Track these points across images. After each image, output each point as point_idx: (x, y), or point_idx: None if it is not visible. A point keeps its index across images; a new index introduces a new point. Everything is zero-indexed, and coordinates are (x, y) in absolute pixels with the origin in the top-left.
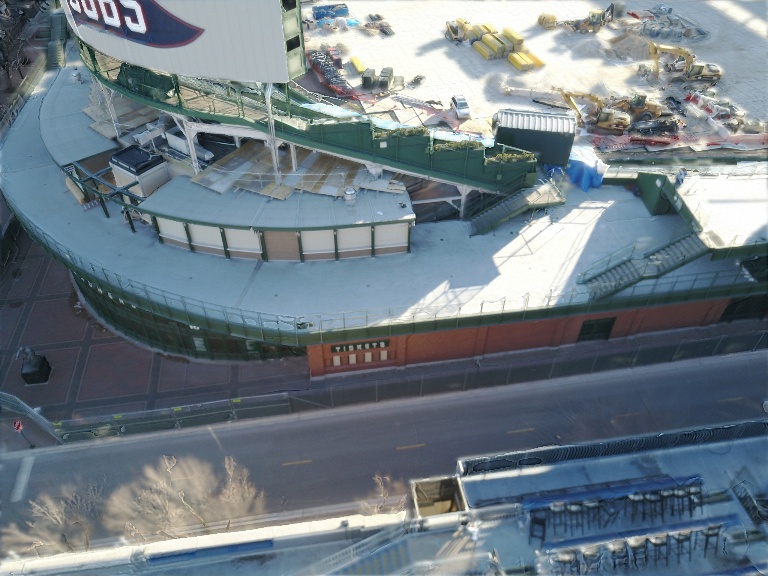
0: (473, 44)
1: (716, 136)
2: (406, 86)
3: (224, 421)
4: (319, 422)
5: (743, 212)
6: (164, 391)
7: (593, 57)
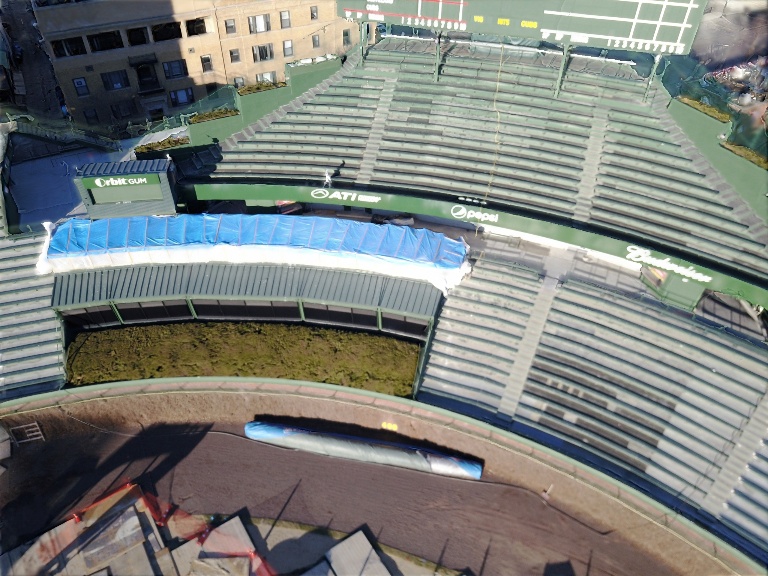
0: None
1: None
2: None
3: None
4: None
5: None
6: None
7: None
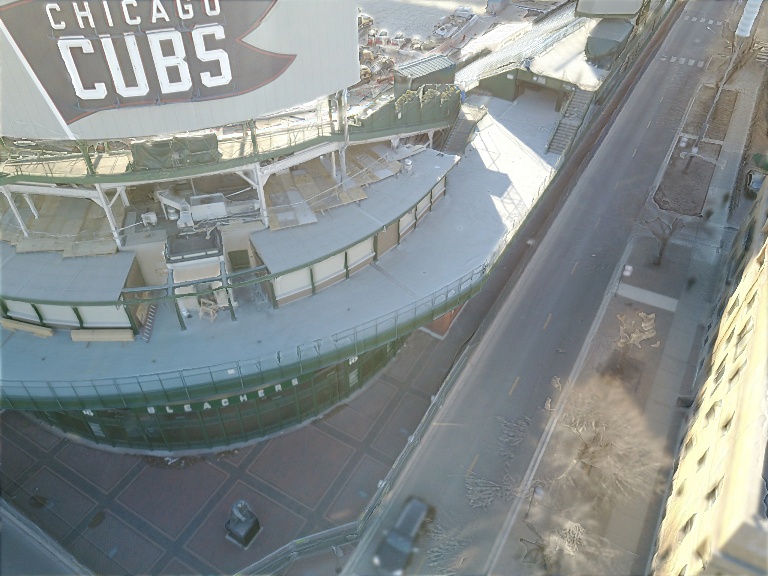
0: None
1: (415, 59)
2: None
3: (438, 409)
4: (486, 356)
5: (574, 69)
6: (365, 436)
7: None
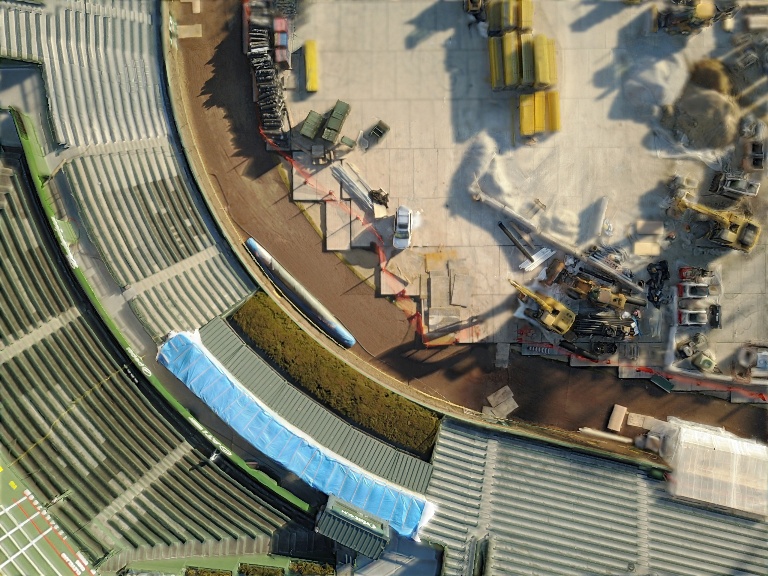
0: (489, 40)
1: (660, 357)
2: (358, 144)
3: None
4: None
5: None
6: None
7: (641, 119)
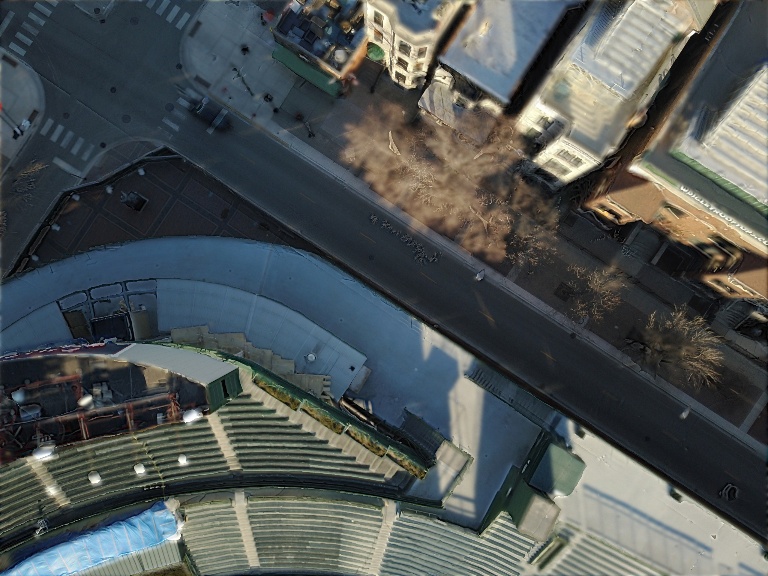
0: None
1: None
2: None
3: None
4: None
5: None
6: None
7: None
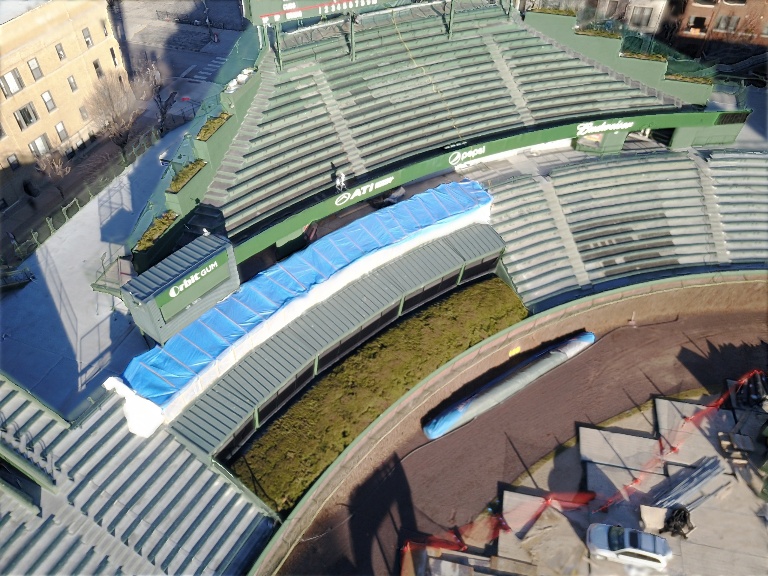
0: None
1: None
2: None
3: None
4: None
5: None
6: None
7: None
